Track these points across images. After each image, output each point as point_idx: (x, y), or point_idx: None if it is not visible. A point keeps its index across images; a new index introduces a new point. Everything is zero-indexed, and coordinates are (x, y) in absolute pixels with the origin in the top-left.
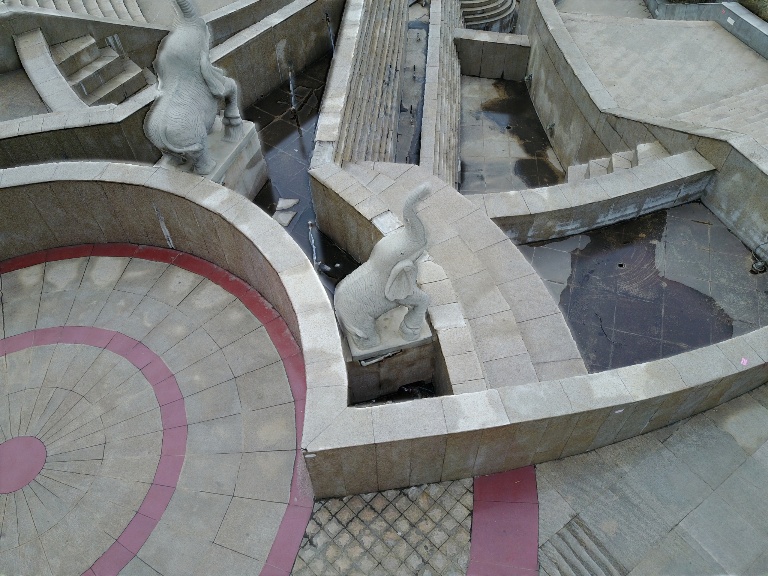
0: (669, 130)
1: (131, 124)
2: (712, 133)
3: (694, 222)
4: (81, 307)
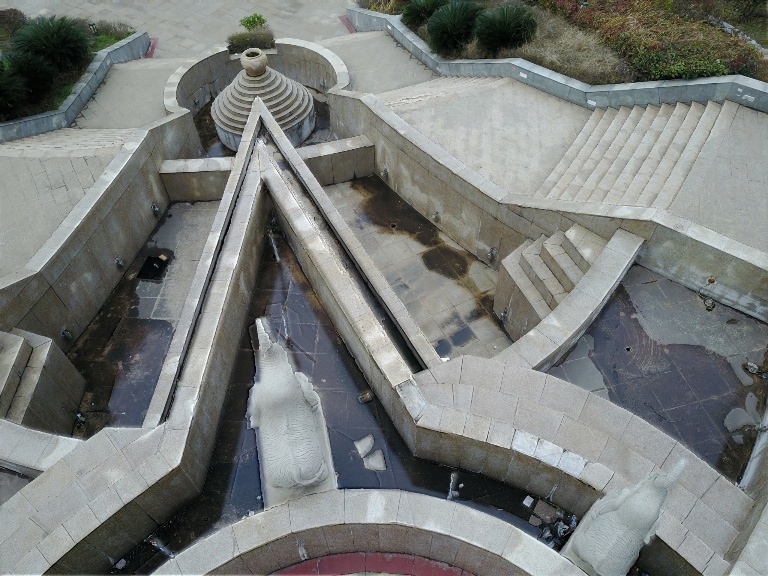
0: (588, 216)
1: (184, 456)
2: (630, 213)
3: (645, 284)
4: None
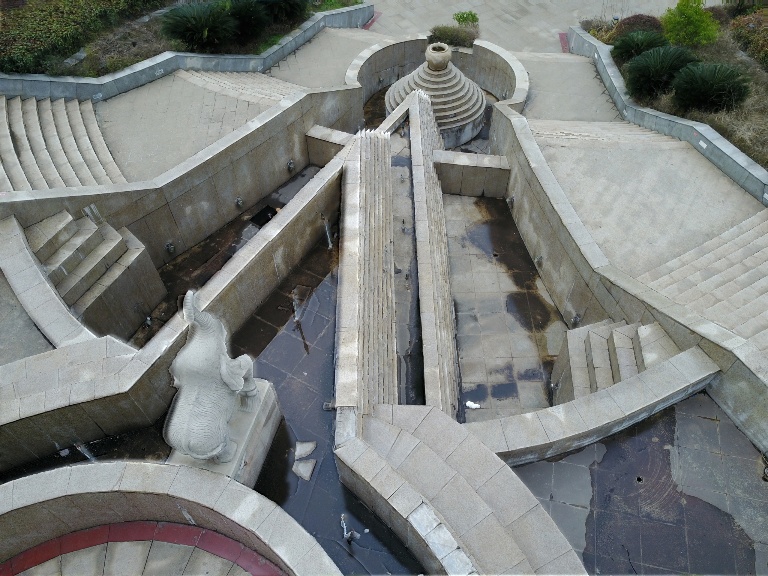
0: (669, 319)
1: (138, 386)
2: (714, 334)
3: (702, 419)
4: None
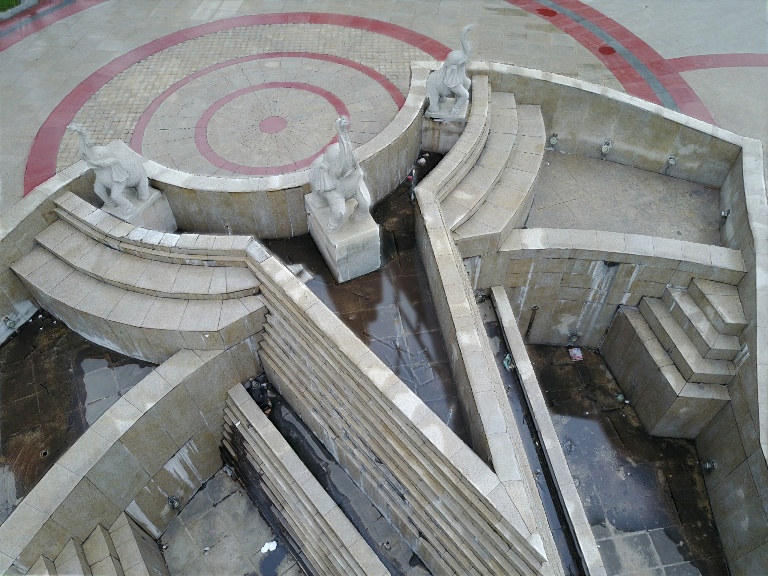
0: None
1: None
2: None
3: None
4: None
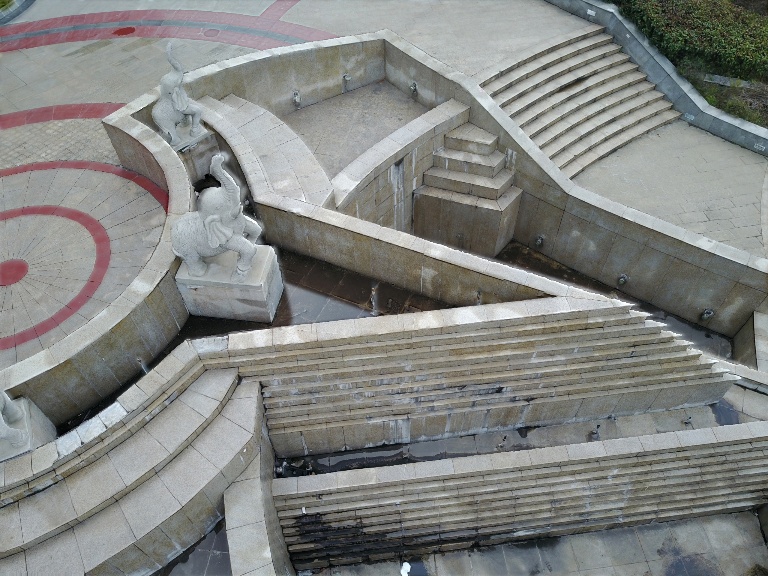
0: None
1: (266, 209)
2: None
3: None
4: (127, 256)
